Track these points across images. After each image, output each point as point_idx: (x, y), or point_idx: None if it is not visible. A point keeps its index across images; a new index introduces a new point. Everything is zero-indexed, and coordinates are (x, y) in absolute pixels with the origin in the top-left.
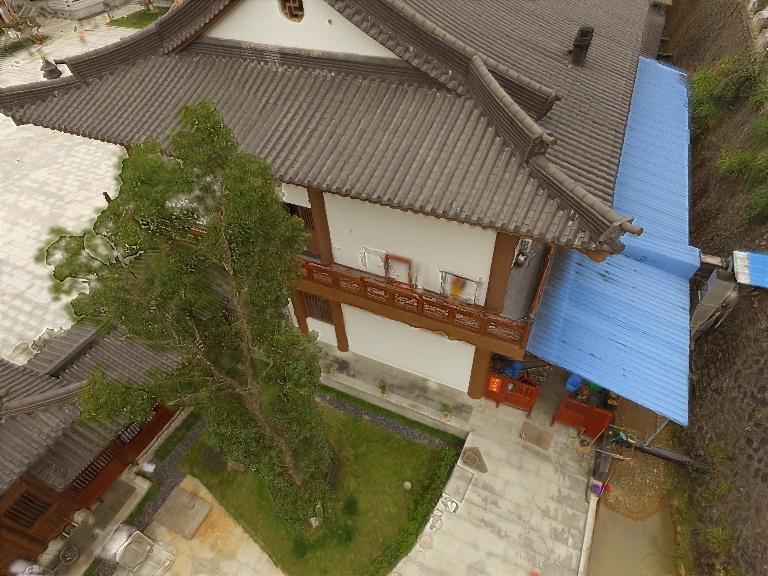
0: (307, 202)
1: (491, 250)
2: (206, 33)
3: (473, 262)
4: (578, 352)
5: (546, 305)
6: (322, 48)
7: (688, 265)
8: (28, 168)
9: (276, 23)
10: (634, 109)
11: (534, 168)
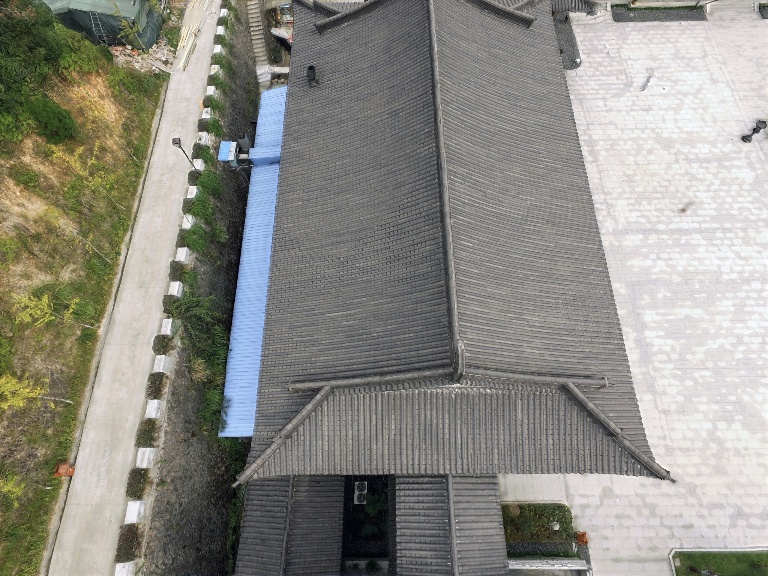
0: None
1: None
2: None
3: None
4: None
5: None
6: None
7: None
8: (765, 176)
9: None
10: None
11: None
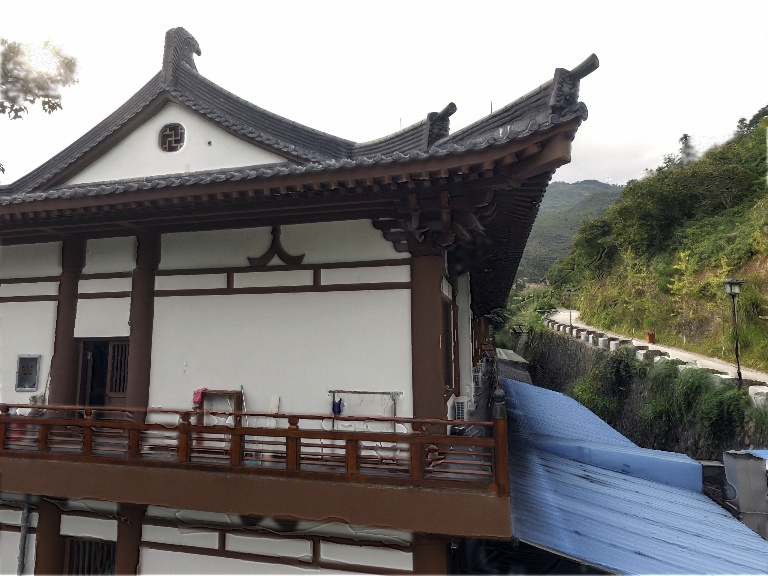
0: (125, 326)
1: (407, 328)
2: (68, 182)
3: (382, 363)
4: (611, 547)
5: (519, 492)
6: (197, 170)
7: (686, 466)
8: None
9: (152, 156)
10: (535, 399)
11: (439, 146)
